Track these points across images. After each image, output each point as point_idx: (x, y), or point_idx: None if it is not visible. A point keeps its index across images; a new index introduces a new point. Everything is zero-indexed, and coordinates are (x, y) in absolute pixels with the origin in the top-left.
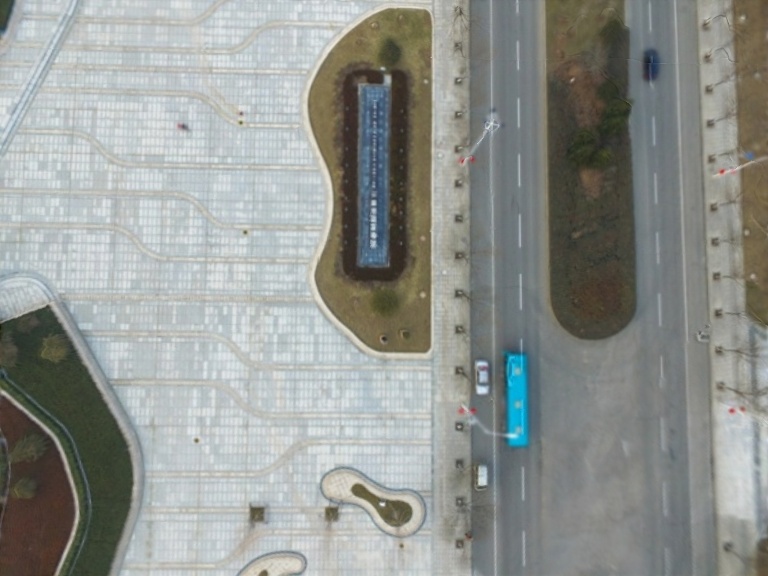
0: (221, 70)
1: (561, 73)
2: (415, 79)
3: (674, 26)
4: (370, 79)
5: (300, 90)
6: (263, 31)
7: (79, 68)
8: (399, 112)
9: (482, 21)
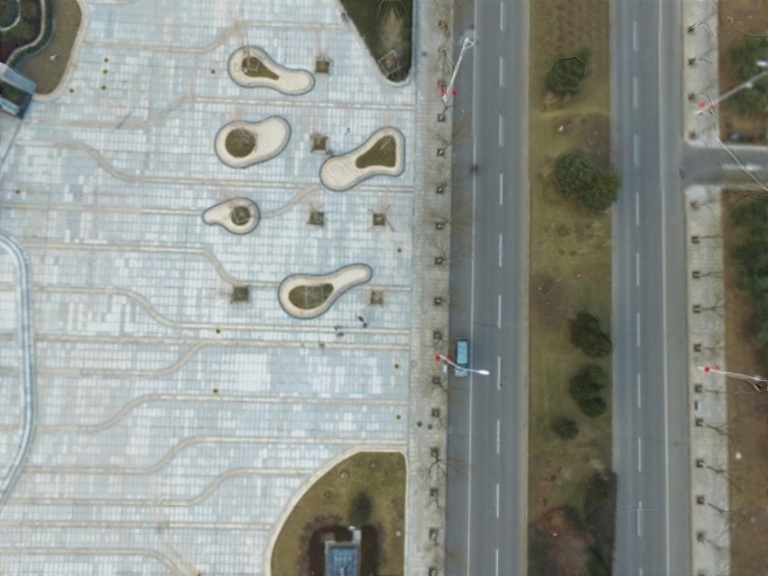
0: (178, 524)
1: (543, 525)
2: (387, 533)
3: (665, 465)
4: (338, 536)
5: (263, 547)
6: (225, 480)
7: (25, 525)
8: (368, 575)
9: (460, 464)
